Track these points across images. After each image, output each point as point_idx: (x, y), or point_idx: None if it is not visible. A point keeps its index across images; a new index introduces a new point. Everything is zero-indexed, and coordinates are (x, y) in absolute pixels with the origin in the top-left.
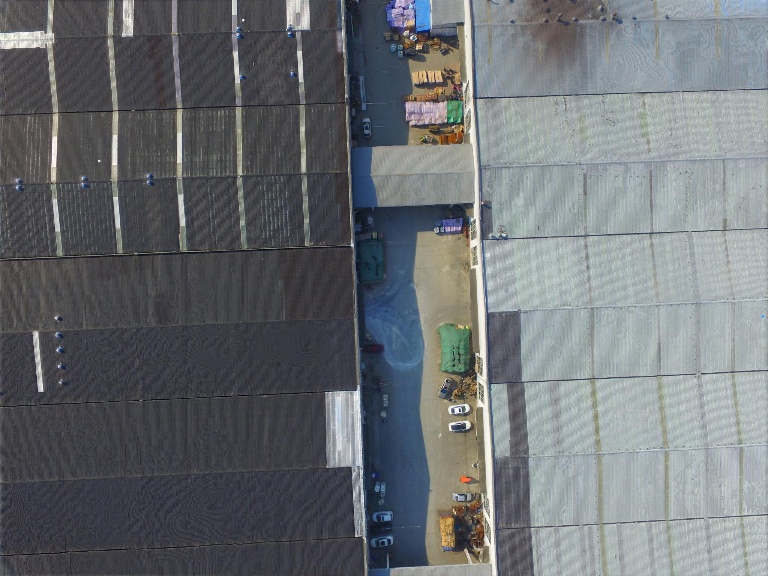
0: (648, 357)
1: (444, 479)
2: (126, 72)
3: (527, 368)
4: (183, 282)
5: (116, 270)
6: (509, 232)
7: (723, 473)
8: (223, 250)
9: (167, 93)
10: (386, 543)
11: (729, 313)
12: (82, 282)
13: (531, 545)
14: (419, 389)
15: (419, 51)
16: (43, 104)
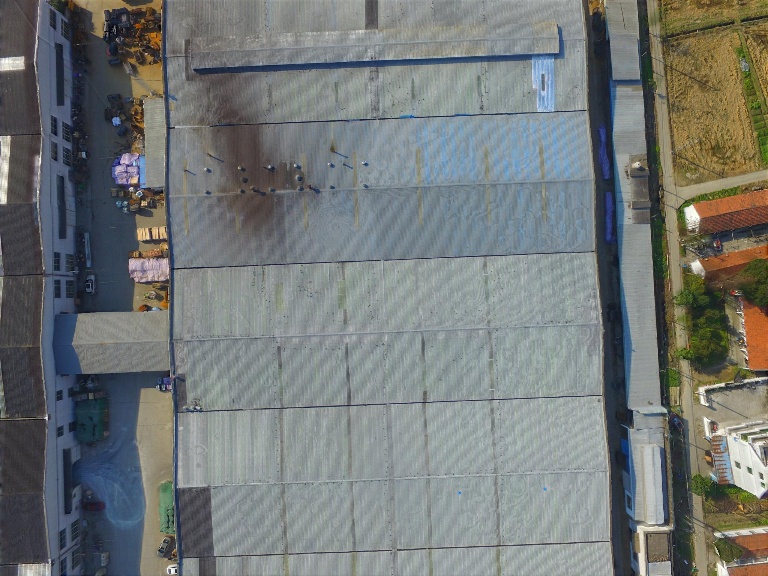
0: (342, 533)
1: None
2: None
3: (219, 543)
4: None
5: None
6: (203, 405)
7: None
8: None
9: None
10: None
11: (424, 489)
12: None
13: None
14: (140, 547)
15: (145, 206)
16: None
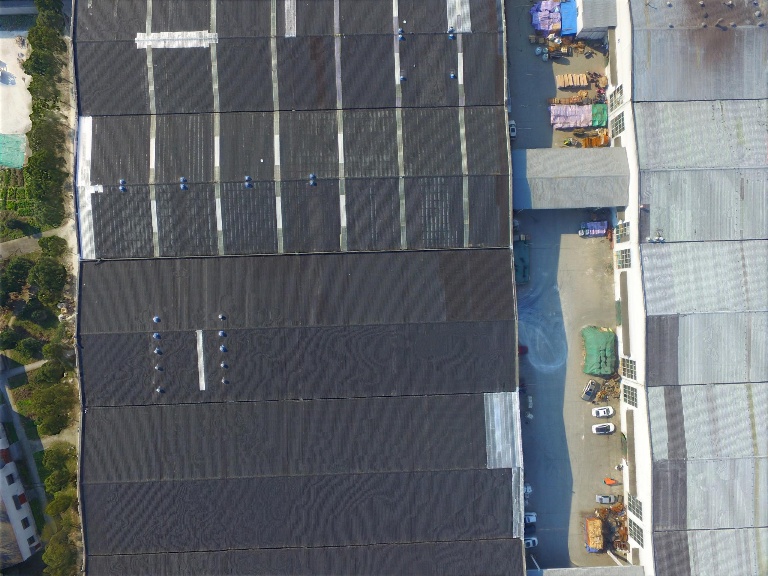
0: None
1: (587, 481)
2: (288, 72)
3: (684, 371)
4: (344, 282)
5: (277, 269)
6: (666, 236)
7: None
8: (383, 251)
9: (328, 94)
10: (531, 544)
11: None
12: (244, 281)
13: (687, 548)
14: (562, 391)
15: (563, 54)
16: (205, 103)
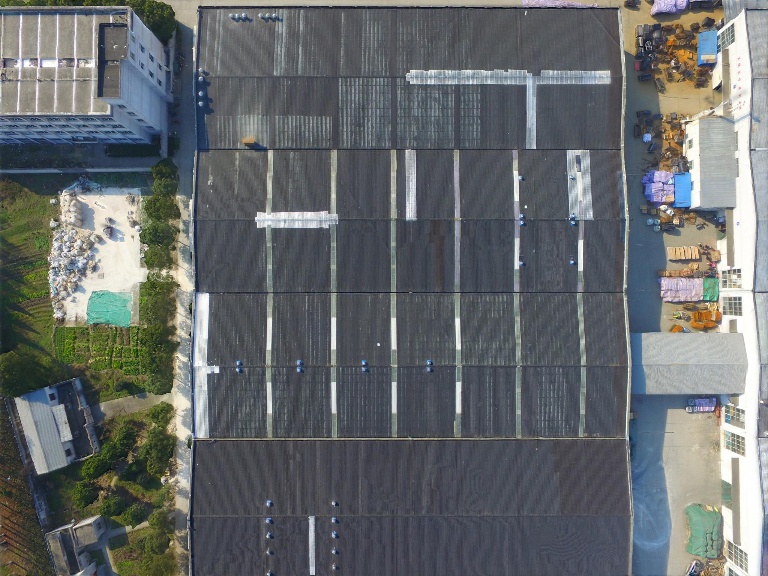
0: None
1: None
2: (406, 255)
3: None
4: (458, 470)
5: (390, 454)
6: None
7: None
8: (498, 438)
9: (446, 277)
10: None
11: None
12: (357, 466)
13: None
14: (665, 570)
15: (675, 225)
16: (322, 283)
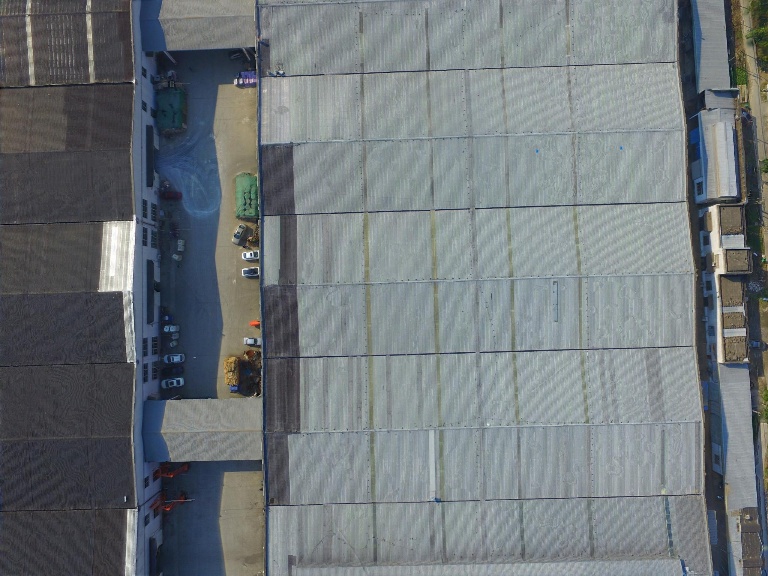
0: (421, 191)
1: (237, 324)
2: None
3: (300, 200)
4: None
5: None
6: (286, 69)
7: (494, 306)
8: (12, 86)
9: None
10: (175, 383)
11: (502, 147)
12: None
13: (299, 374)
14: (215, 236)
15: None
16: None
